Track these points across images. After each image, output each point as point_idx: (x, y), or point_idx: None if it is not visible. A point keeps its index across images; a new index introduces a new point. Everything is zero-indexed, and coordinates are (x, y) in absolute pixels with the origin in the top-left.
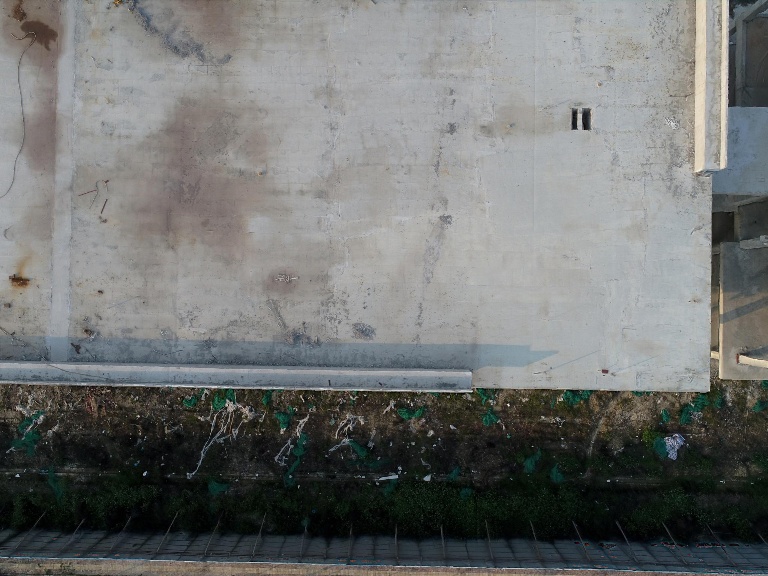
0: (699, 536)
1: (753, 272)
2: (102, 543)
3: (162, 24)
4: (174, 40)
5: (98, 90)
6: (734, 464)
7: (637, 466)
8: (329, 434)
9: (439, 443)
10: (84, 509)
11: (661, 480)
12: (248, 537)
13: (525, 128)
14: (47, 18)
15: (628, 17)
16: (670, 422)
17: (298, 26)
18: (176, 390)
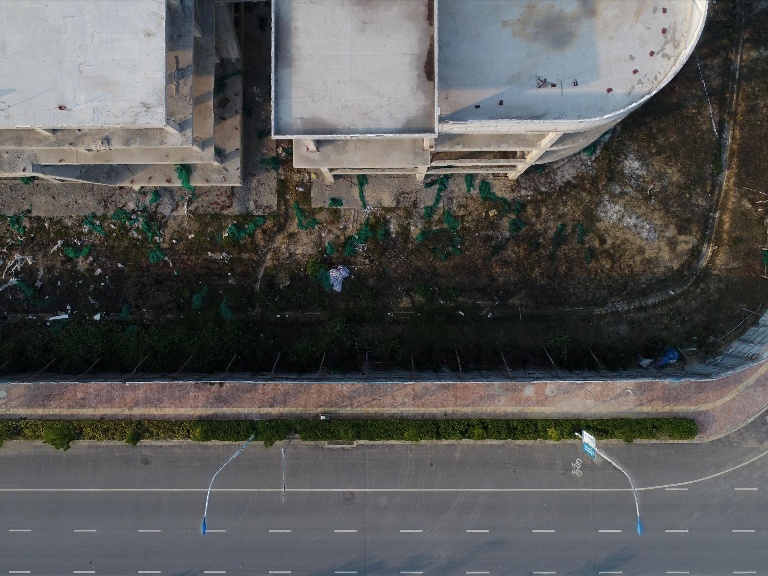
0: (363, 366)
1: None
2: None
3: None
4: None
5: None
6: (398, 294)
7: (302, 299)
8: None
9: (106, 281)
10: None
11: (329, 314)
12: None
13: None
14: None
15: None
16: (335, 255)
17: None
18: None
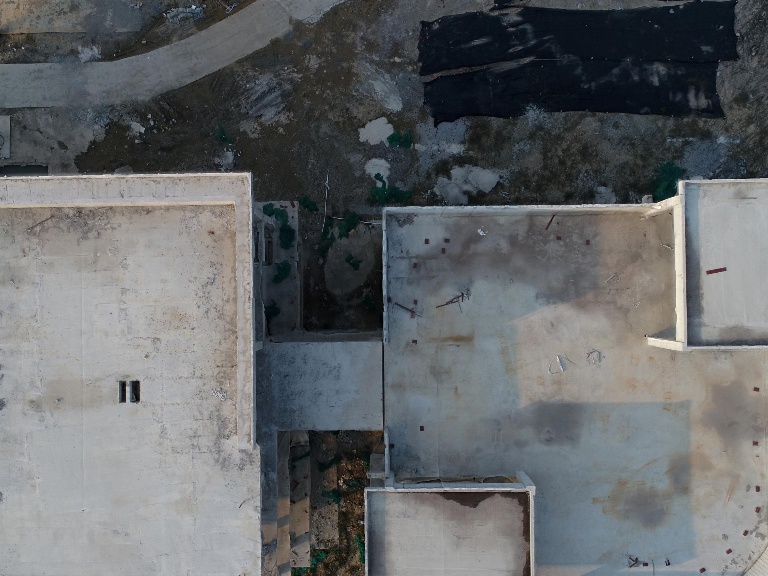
0: None
1: None
2: None
3: None
4: None
5: None
6: None
7: None
8: None
9: None
10: None
11: None
12: None
13: (73, 402)
14: None
15: (174, 287)
16: None
17: None
18: None
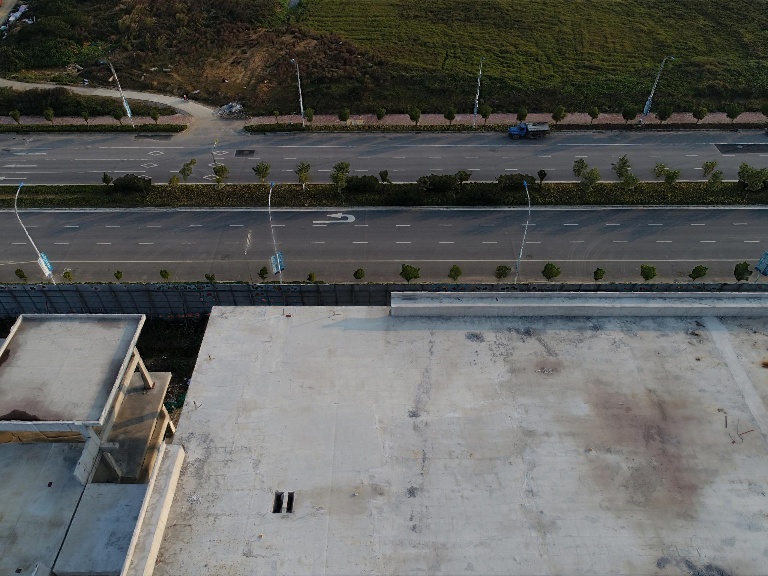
0: None
1: (117, 452)
2: None
3: None
4: None
5: None
6: (152, 367)
7: None
8: None
9: None
10: None
11: None
12: None
13: (340, 493)
14: None
15: None
16: None
17: None
18: None
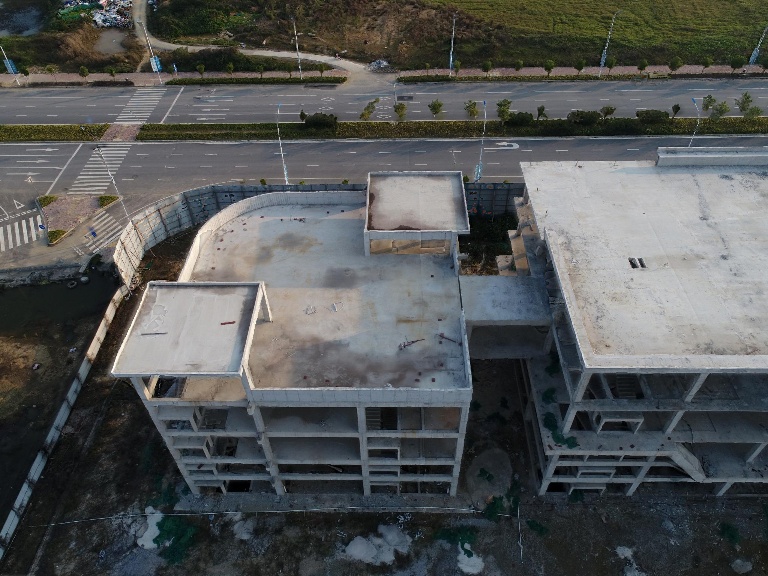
0: None
1: None
2: None
3: None
4: None
5: None
6: None
7: None
8: None
9: None
10: None
11: None
12: None
13: (674, 258)
14: None
15: (626, 315)
16: None
17: None
18: None
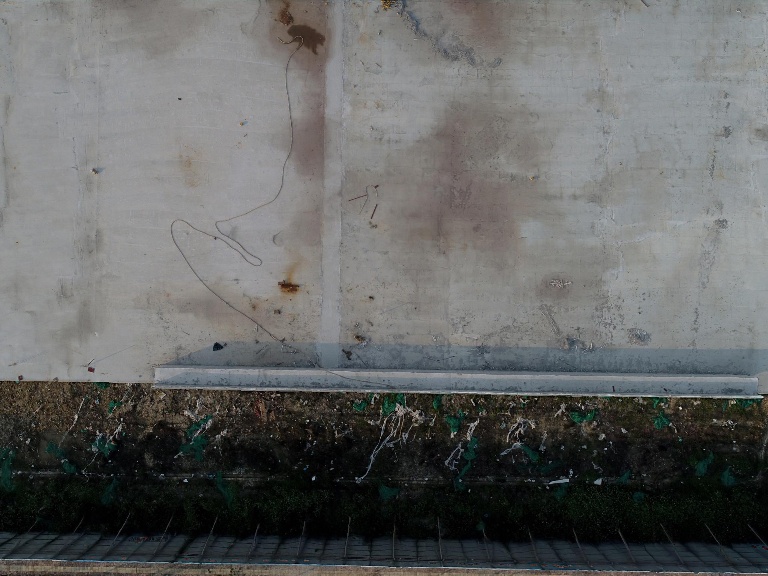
0: None
1: None
2: (283, 548)
3: (431, 27)
4: (443, 44)
5: (367, 94)
6: None
7: None
8: (500, 438)
9: (611, 446)
10: (258, 514)
11: None
12: (425, 542)
13: None
14: (314, 22)
15: None
16: None
17: (569, 29)
18: (345, 394)
